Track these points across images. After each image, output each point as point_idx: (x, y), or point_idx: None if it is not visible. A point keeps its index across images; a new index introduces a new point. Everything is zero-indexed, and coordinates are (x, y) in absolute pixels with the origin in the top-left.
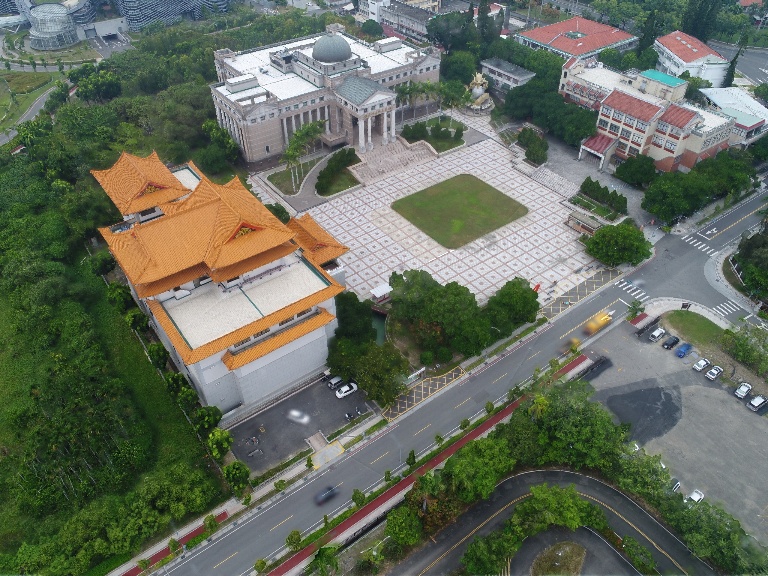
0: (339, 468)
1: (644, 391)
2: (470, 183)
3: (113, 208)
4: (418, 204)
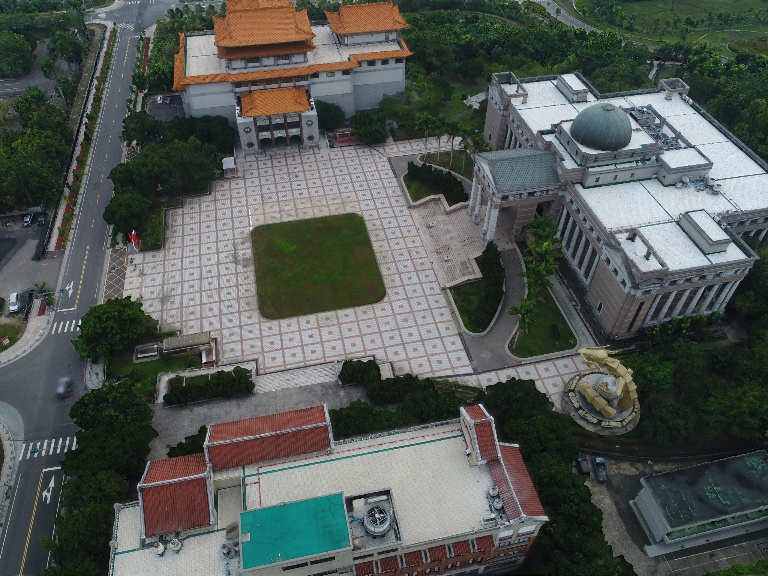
0: (122, 125)
1: None
2: (359, 291)
3: (420, 56)
4: (344, 232)
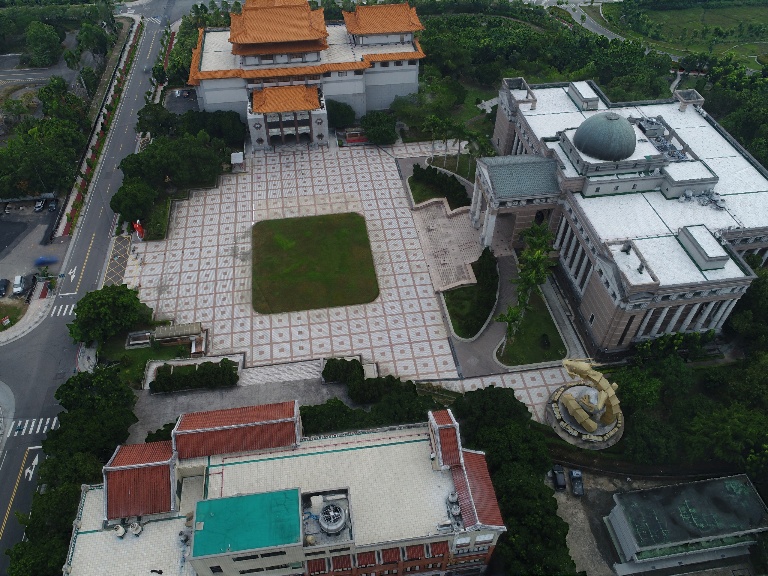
0: None
1: (5, 246)
2: (352, 290)
3: (437, 58)
4: (344, 231)
